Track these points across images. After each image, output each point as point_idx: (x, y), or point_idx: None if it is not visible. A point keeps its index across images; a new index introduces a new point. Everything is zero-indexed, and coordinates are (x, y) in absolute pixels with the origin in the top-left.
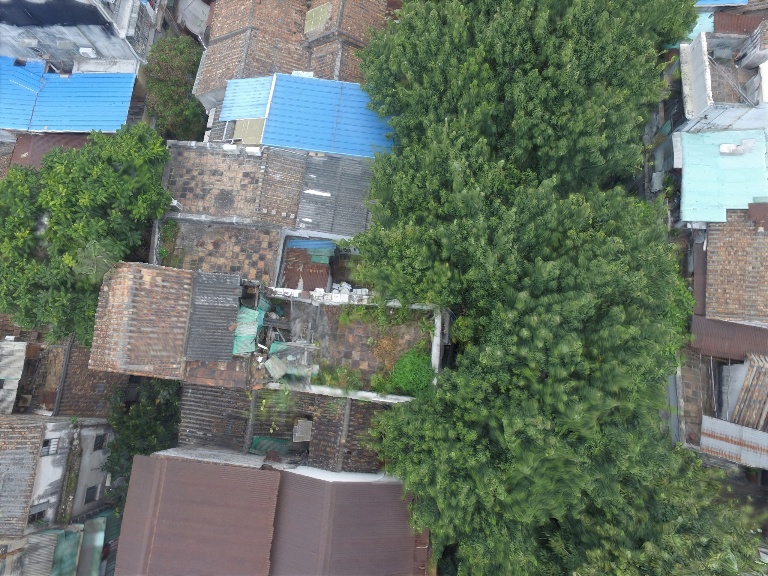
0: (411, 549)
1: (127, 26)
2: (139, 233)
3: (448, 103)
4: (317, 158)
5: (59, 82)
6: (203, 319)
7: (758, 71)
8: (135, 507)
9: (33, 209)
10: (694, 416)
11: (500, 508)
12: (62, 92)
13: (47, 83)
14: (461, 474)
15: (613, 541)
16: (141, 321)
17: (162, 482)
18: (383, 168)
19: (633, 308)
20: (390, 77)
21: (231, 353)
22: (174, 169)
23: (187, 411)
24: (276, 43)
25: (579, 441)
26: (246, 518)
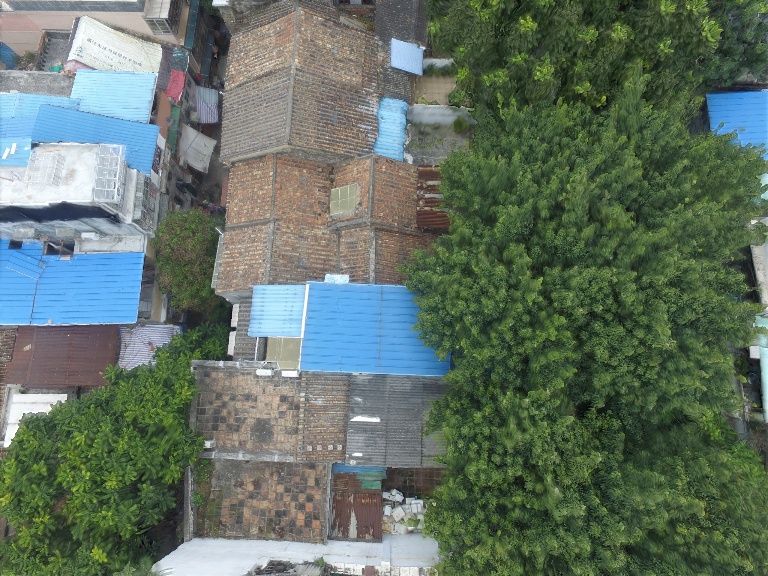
0: None
1: (133, 209)
2: (172, 493)
3: (519, 356)
4: (361, 377)
5: (60, 265)
6: None
7: None
8: None
9: (53, 493)
10: None
11: None
12: (64, 277)
13: (47, 267)
14: None
15: None
16: None
17: None
18: (453, 441)
19: None
20: (447, 316)
21: None
22: (202, 394)
23: None
24: (301, 231)
25: None
26: None
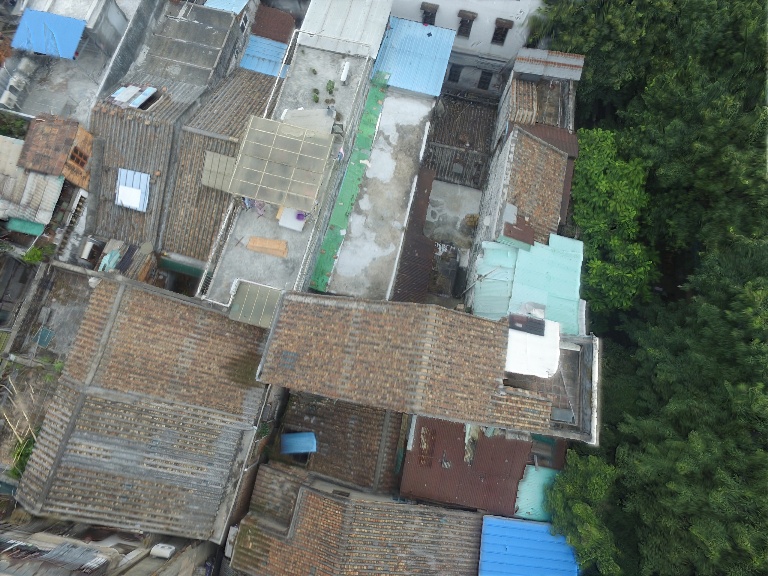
0: None
1: None
2: None
3: None
4: None
5: None
6: None
7: None
8: None
9: None
10: None
11: None
12: None
13: None
14: None
15: None
16: None
17: None
18: None
19: None
20: None
21: None
22: None
23: None
24: None
25: None
26: None
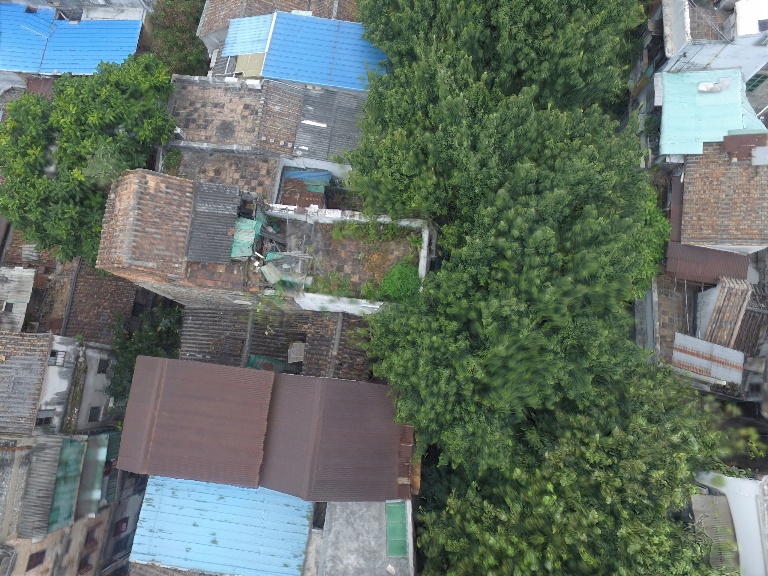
0: (396, 446)
1: None
2: (144, 156)
3: (437, 28)
4: (314, 91)
5: (69, 28)
6: (204, 224)
7: (734, 9)
8: (137, 402)
9: (45, 127)
10: (670, 341)
11: (479, 397)
12: (71, 37)
13: (57, 29)
14: (442, 363)
15: (584, 431)
16: (146, 222)
17: (163, 378)
18: (375, 87)
19: (605, 208)
20: (384, 6)
21: (229, 256)
22: (178, 102)
23: (187, 337)
24: None
25: (552, 330)
26: (241, 412)
